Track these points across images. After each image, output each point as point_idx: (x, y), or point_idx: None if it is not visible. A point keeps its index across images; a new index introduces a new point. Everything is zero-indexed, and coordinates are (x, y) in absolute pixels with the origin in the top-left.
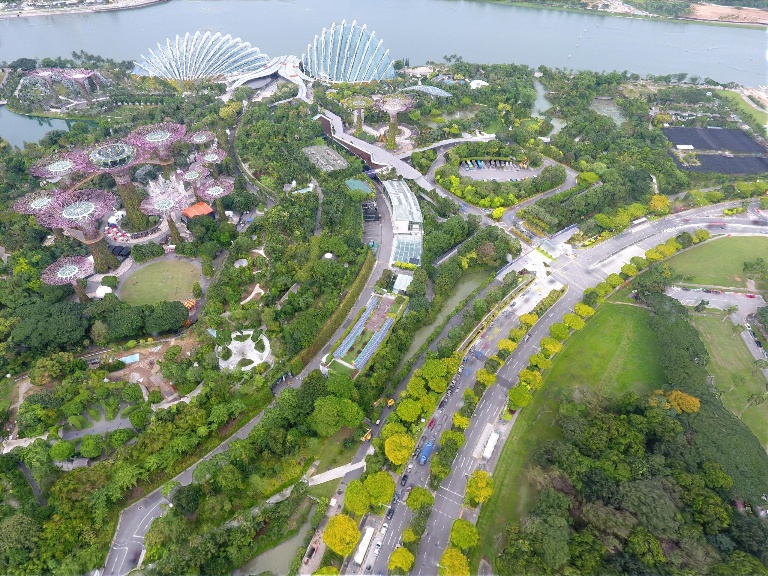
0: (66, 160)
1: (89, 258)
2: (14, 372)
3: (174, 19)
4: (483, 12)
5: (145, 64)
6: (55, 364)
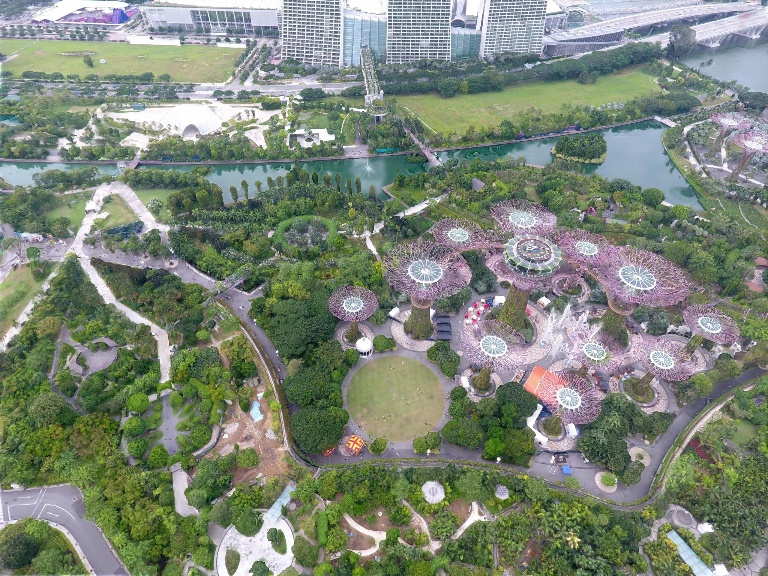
0: (537, 218)
1: None
2: (258, 322)
3: None
4: None
5: None
6: (235, 351)
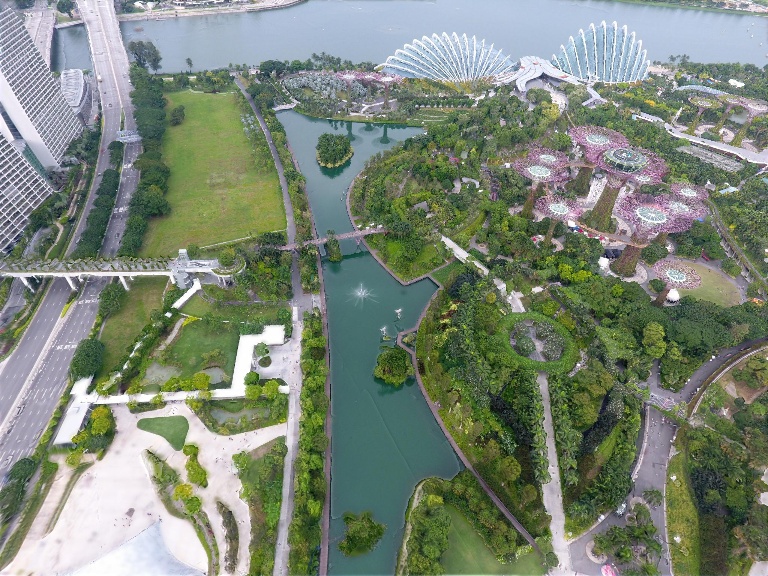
0: (534, 165)
1: (602, 262)
2: None
3: (339, 19)
4: (611, 11)
5: (403, 66)
6: None
